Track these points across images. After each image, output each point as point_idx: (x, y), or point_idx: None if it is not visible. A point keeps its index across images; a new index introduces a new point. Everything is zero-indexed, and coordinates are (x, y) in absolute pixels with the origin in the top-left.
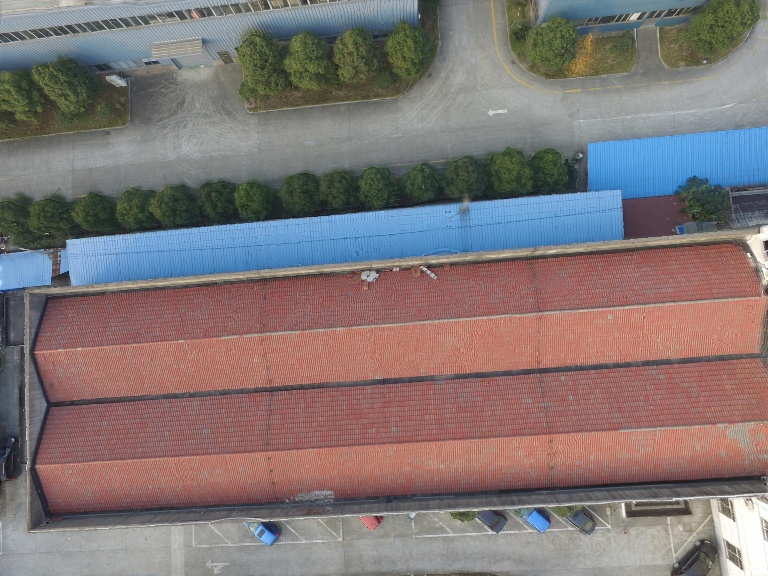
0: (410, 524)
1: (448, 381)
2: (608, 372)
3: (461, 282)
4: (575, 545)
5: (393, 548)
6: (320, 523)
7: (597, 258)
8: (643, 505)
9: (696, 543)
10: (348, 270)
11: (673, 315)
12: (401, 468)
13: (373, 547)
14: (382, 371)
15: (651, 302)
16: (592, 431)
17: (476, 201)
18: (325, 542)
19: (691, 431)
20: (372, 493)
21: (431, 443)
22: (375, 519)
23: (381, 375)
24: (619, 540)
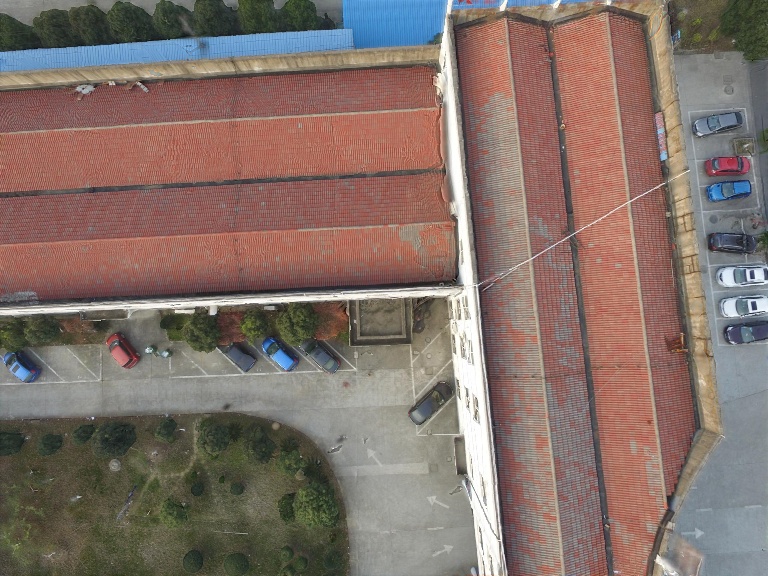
0: (167, 366)
1: (154, 190)
2: (304, 183)
3: (173, 97)
4: (322, 386)
5: (149, 388)
6: (80, 364)
7: (302, 77)
8: (368, 335)
9: (435, 385)
10: (67, 84)
11: (359, 125)
12: (97, 267)
13: (130, 387)
14: (97, 183)
15: (338, 111)
16: (273, 230)
17: (217, 37)
18: (84, 382)
19: (366, 232)
20: (74, 295)
21: (121, 240)
22: (126, 355)
23: (91, 184)
24: (364, 382)
